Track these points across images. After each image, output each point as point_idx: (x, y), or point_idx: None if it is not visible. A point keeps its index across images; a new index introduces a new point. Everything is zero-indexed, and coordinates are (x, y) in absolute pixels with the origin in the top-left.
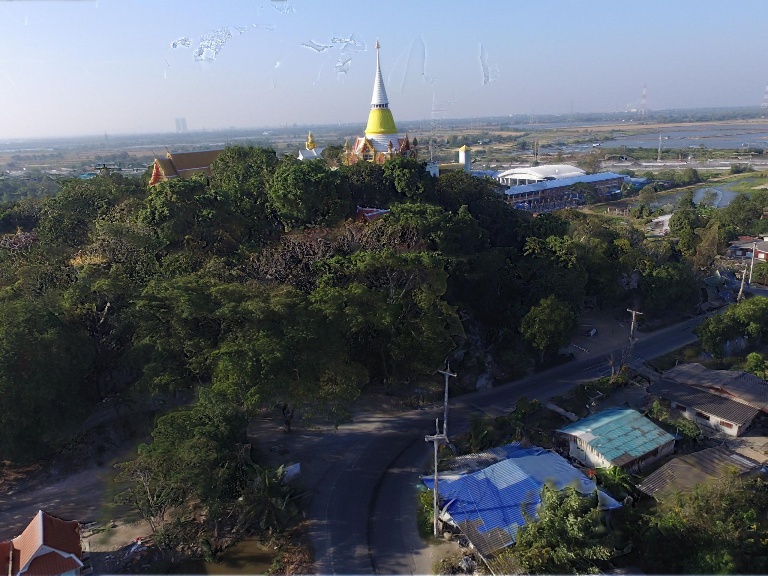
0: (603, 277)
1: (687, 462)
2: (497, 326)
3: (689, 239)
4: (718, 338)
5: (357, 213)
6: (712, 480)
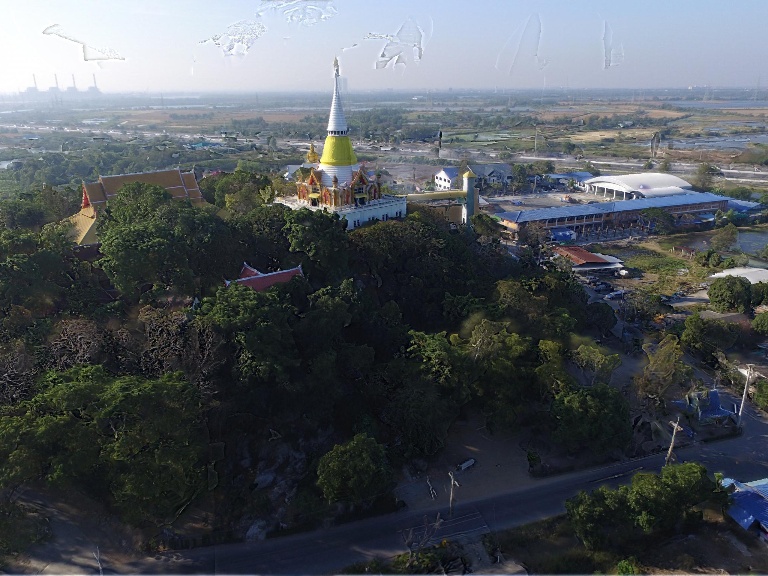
0: (502, 392)
1: None
2: (351, 436)
3: (694, 331)
4: (589, 525)
5: (241, 271)
6: None
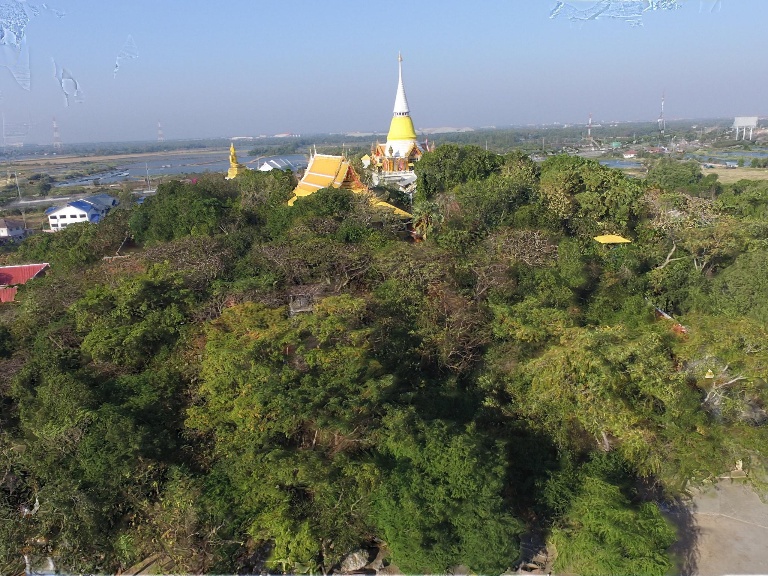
0: None
1: None
2: None
3: None
4: None
5: None
6: None
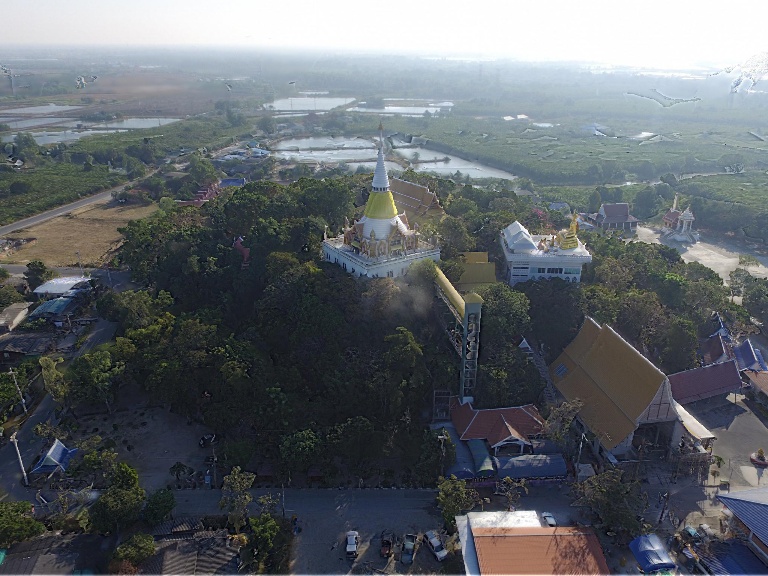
0: None
1: (19, 308)
2: None
3: None
4: None
5: None
6: (4, 290)
